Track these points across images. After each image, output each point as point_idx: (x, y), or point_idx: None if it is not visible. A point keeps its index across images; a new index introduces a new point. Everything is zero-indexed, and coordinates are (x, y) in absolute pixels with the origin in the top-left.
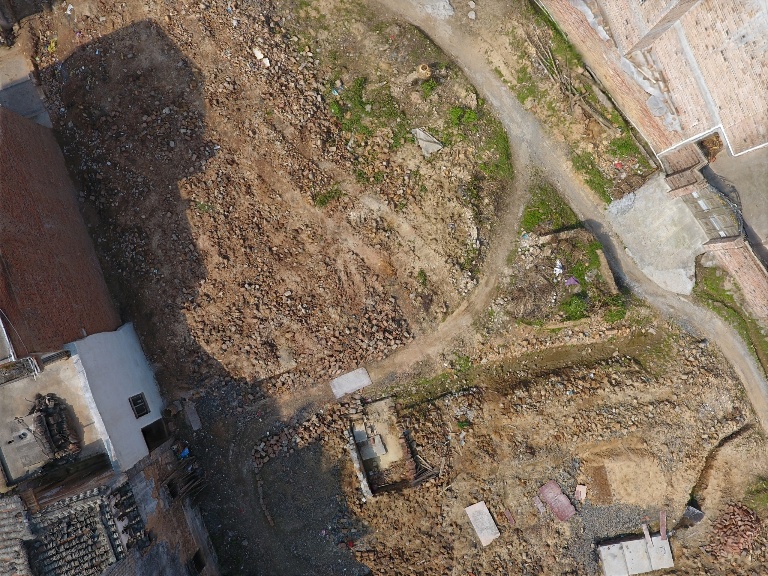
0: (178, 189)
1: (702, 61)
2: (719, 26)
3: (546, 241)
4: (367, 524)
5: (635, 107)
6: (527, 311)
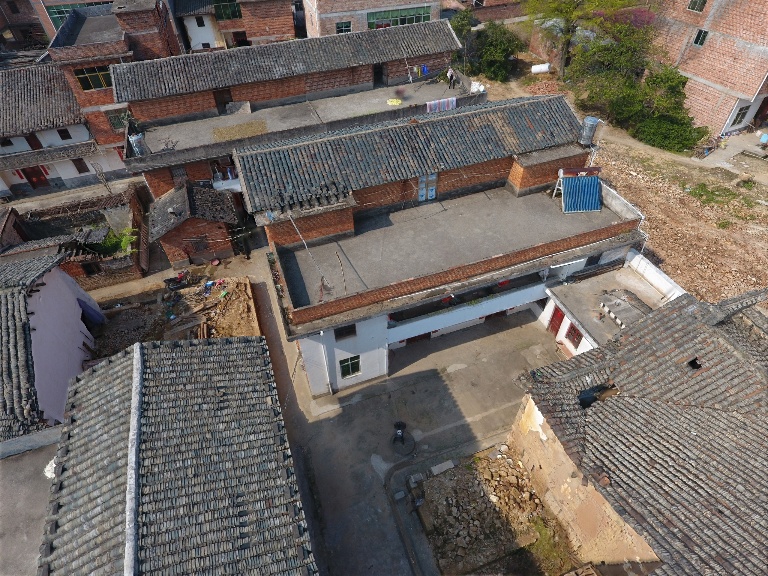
0: None
1: None
2: None
3: None
4: None
5: None
6: None
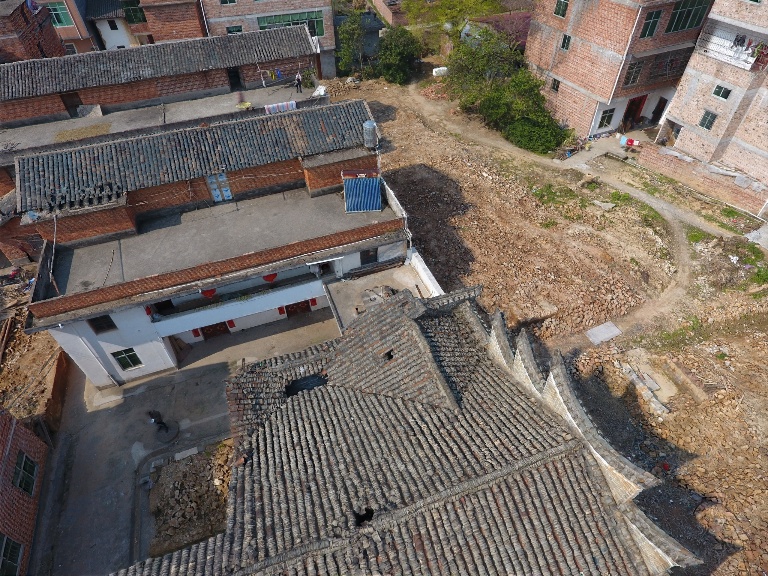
0: (445, 222)
1: (760, 144)
2: (761, 123)
3: (714, 243)
4: (674, 447)
5: (727, 192)
6: (728, 278)
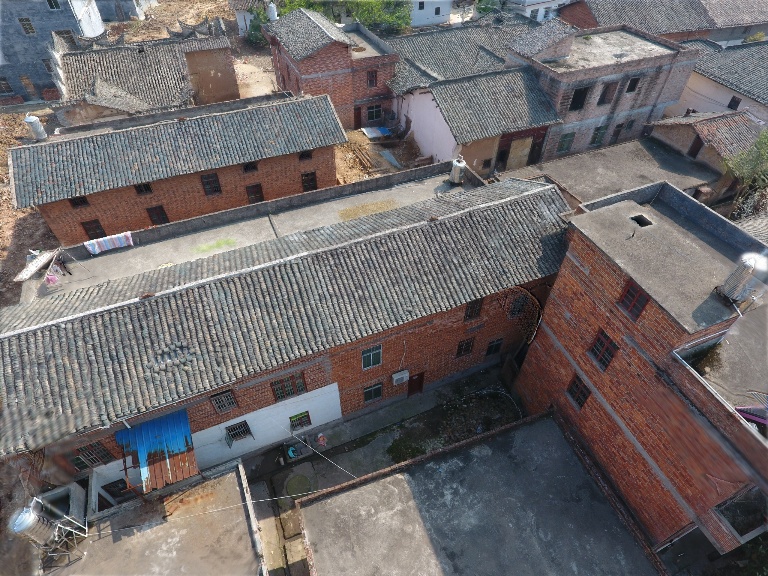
0: (7, 256)
1: None
2: None
3: None
4: None
5: None
6: None
